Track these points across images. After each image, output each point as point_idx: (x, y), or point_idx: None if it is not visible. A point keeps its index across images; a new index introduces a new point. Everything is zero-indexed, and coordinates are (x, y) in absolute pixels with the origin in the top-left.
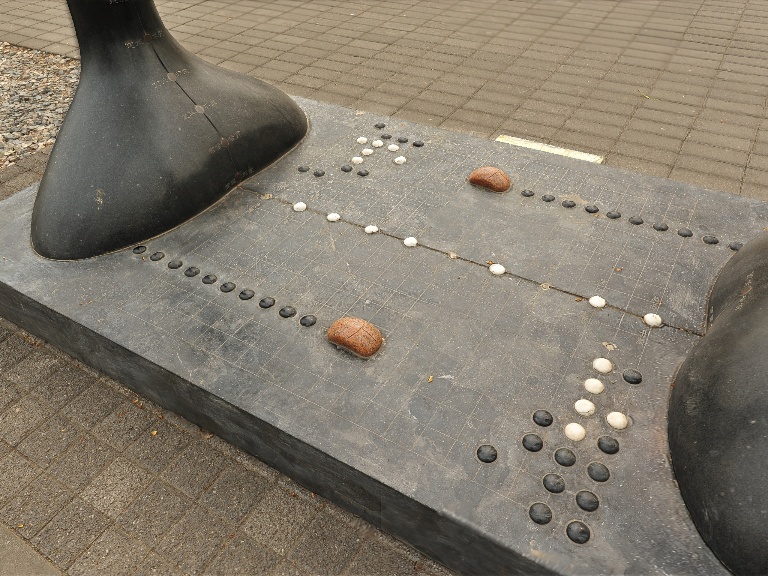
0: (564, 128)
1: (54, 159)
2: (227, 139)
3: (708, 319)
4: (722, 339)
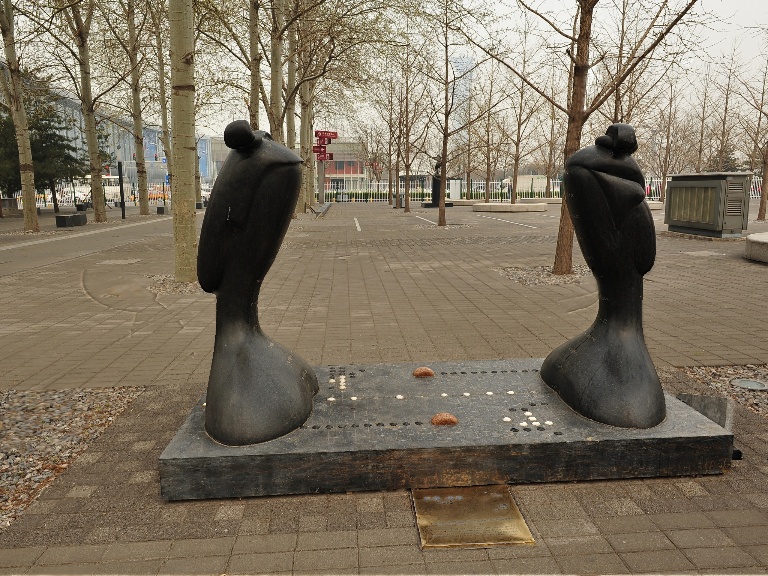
0: None
1: None
2: None
3: None
4: None
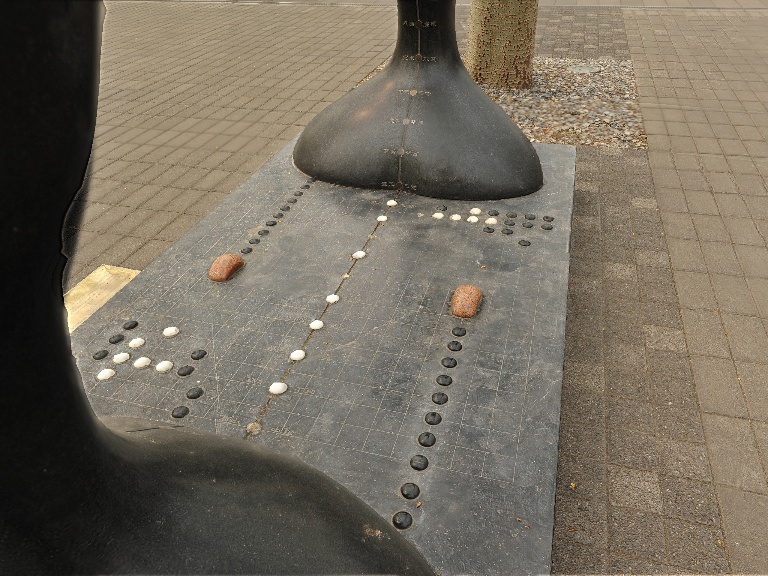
0: None
1: None
2: None
3: (388, 188)
4: (438, 161)
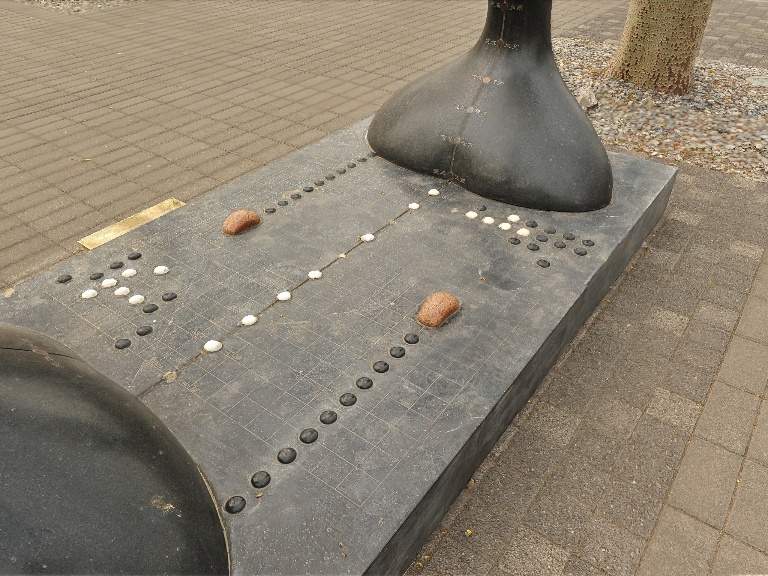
0: (99, 207)
1: (31, 571)
2: (84, 362)
3: (439, 176)
4: (491, 157)
